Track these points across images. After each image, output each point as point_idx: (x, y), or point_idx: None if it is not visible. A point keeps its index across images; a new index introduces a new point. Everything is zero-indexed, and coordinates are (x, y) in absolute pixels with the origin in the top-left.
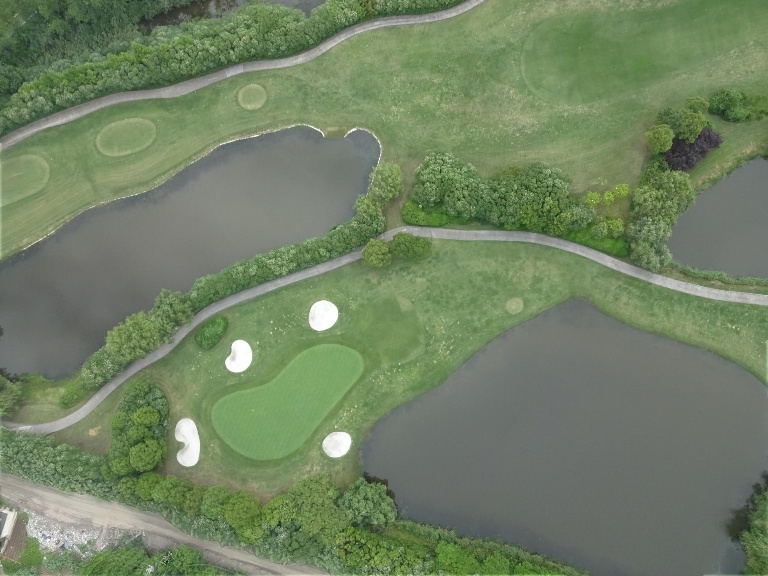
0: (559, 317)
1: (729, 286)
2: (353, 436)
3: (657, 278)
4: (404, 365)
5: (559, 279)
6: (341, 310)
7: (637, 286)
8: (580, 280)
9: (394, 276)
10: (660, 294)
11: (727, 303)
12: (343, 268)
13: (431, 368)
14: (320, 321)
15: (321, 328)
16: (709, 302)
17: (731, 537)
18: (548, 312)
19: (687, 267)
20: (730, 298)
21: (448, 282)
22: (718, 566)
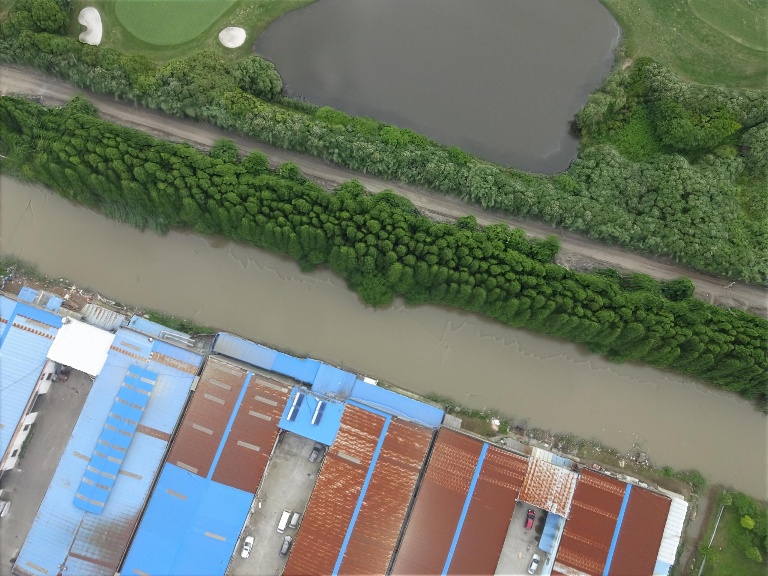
0: None
1: None
2: (248, 32)
3: None
4: None
5: None
6: None
7: None
8: None
9: None
10: None
11: None
12: None
13: None
14: None
15: None
16: None
17: (570, 123)
18: None
19: None
20: None
21: None
22: (558, 144)
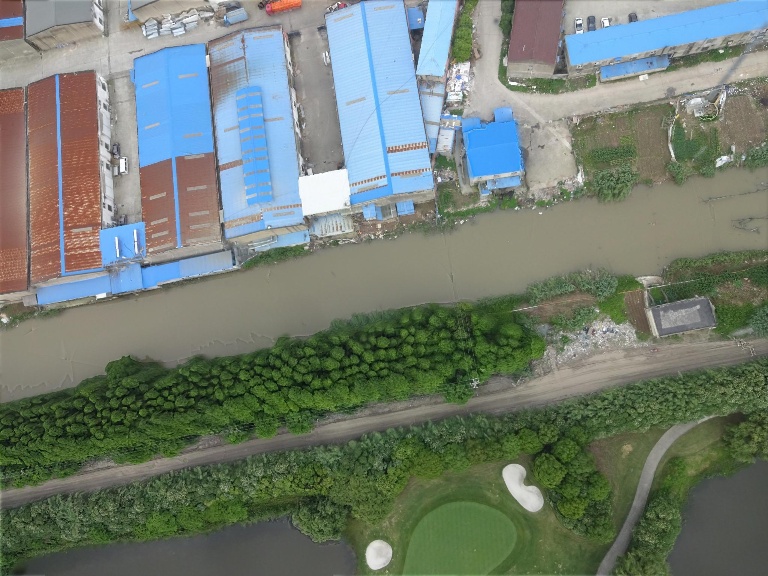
0: None
1: None
2: (368, 569)
3: None
4: None
5: None
6: None
7: None
8: None
9: None
10: None
11: None
12: None
13: None
14: None
15: None
16: None
17: None
18: None
19: None
20: None
21: None
22: None
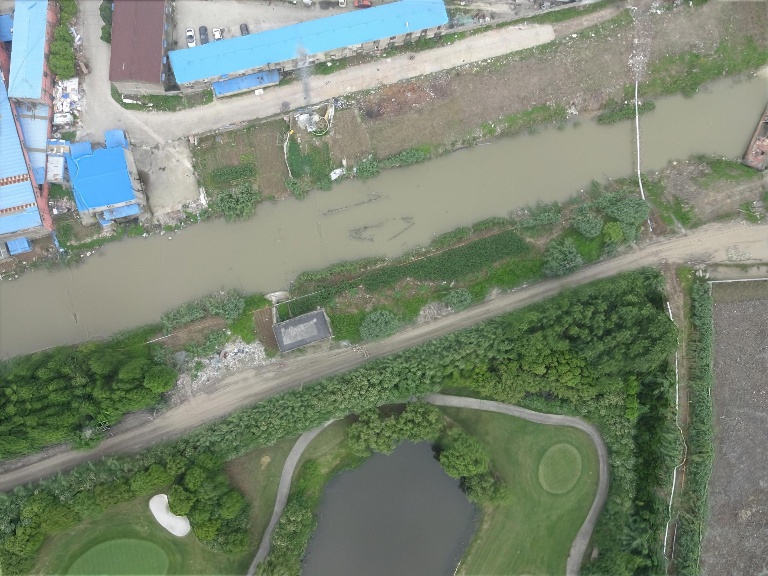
0: None
1: None
2: None
3: None
4: None
5: None
6: None
7: None
8: None
9: None
10: None
11: None
12: None
13: None
14: None
15: None
16: None
17: None
18: None
19: None
20: None
21: None
22: None
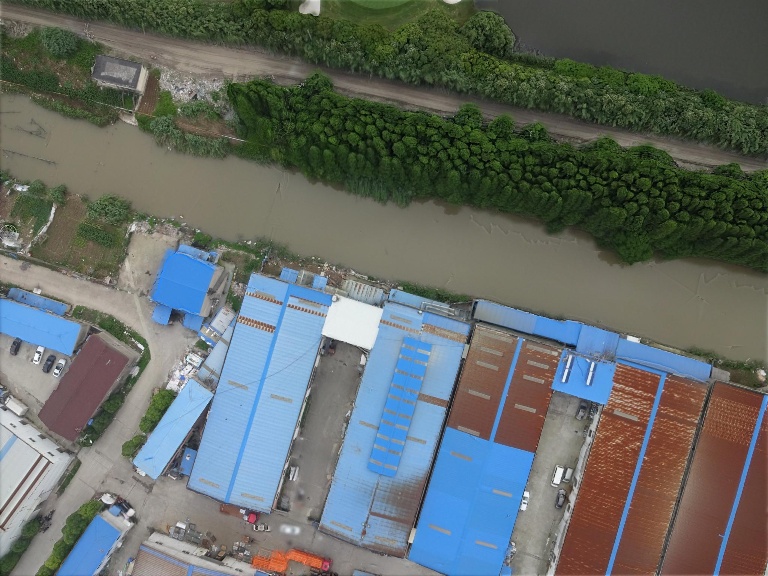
0: None
1: None
2: None
3: None
4: None
5: None
6: None
7: None
8: None
9: None
10: None
11: None
12: None
13: None
14: None
15: None
16: None
17: None
18: None
19: None
20: None
21: None
22: None
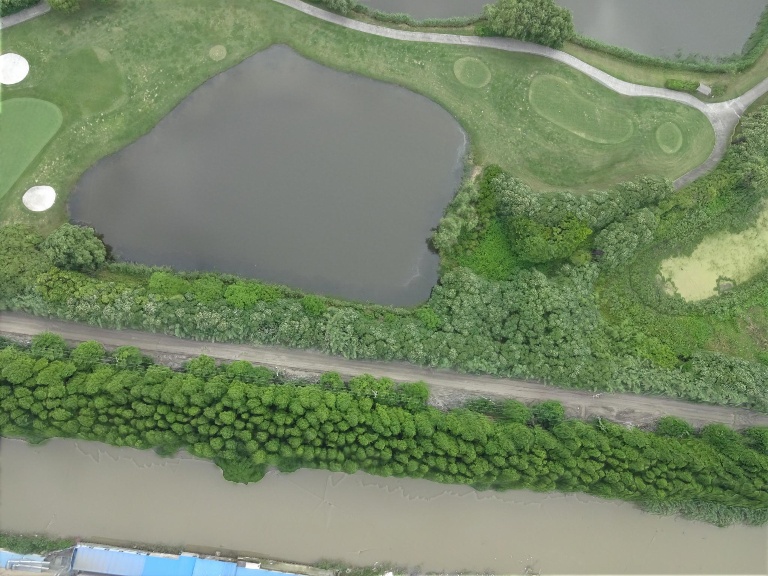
0: (262, 62)
1: (414, 28)
2: (57, 189)
3: (351, 22)
4: (107, 115)
5: (259, 26)
6: (32, 63)
7: (333, 30)
8: (280, 26)
9: (88, 26)
10: (354, 37)
11: (413, 42)
12: (31, 21)
13: (136, 117)
14: (9, 75)
15: (10, 82)
16: (397, 42)
17: (427, 244)
18: (251, 58)
19: (375, 10)
20: (415, 38)
21: (147, 31)
22: (417, 269)
